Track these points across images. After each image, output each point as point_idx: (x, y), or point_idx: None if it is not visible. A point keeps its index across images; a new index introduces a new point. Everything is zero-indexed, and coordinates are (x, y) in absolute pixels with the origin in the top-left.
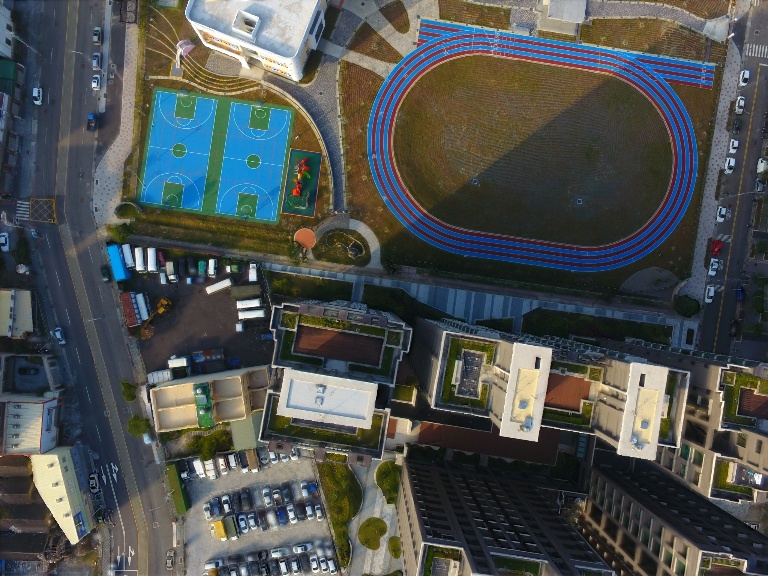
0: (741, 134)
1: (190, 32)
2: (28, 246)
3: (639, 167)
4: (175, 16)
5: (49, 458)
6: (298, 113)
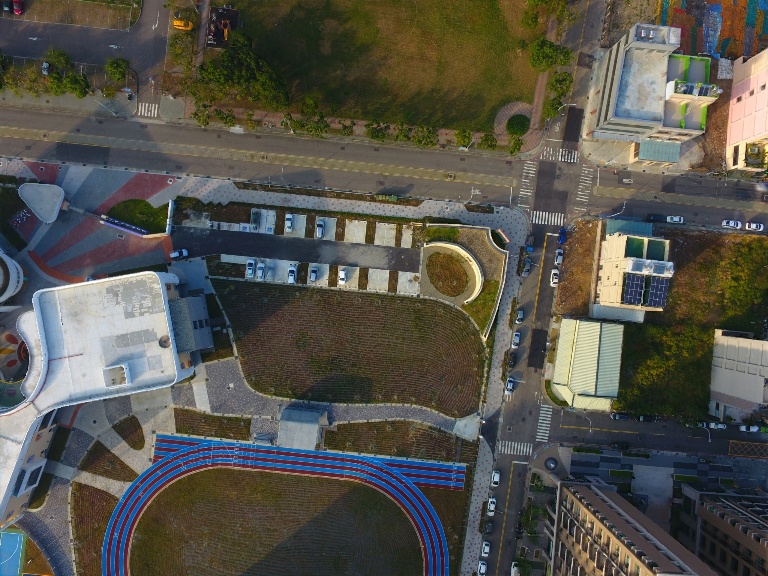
0: (494, 535)
1: None
2: None
3: (389, 574)
4: None
5: None
6: None
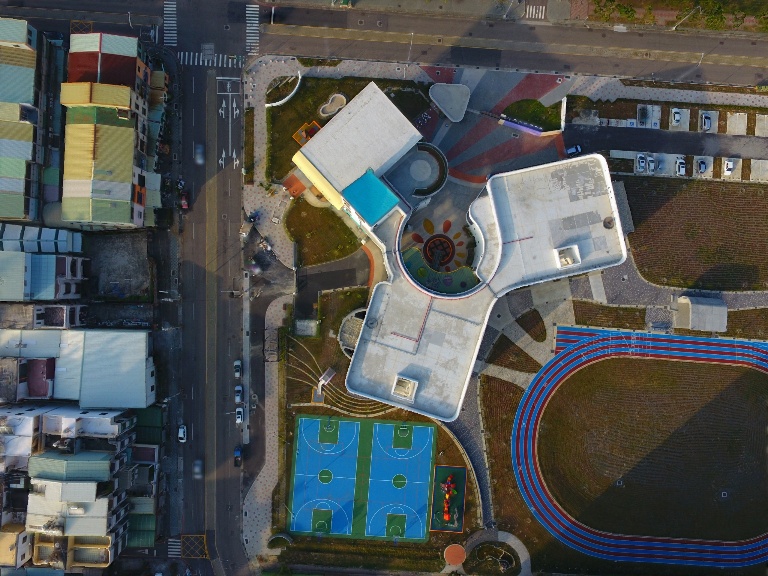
0: None
1: (330, 359)
2: None
3: None
4: (314, 344)
5: None
6: (440, 429)
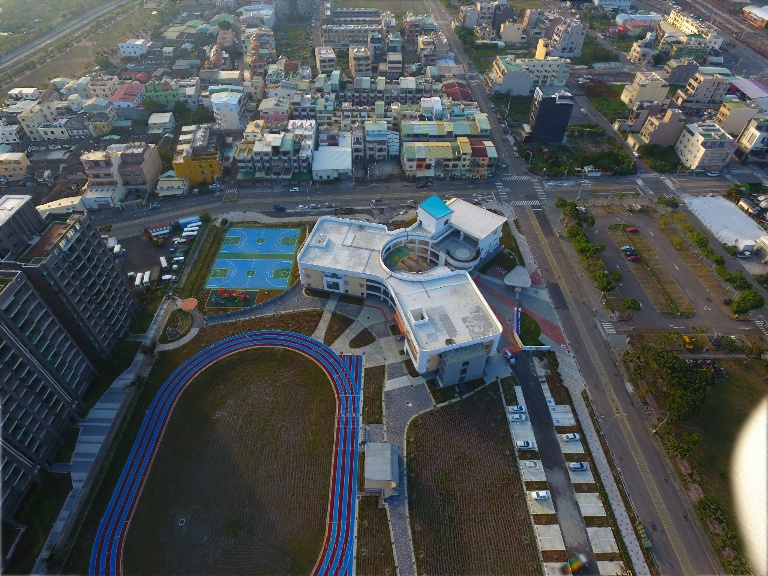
0: None
1: None
2: (211, 193)
3: None
4: None
5: (77, 201)
6: None
